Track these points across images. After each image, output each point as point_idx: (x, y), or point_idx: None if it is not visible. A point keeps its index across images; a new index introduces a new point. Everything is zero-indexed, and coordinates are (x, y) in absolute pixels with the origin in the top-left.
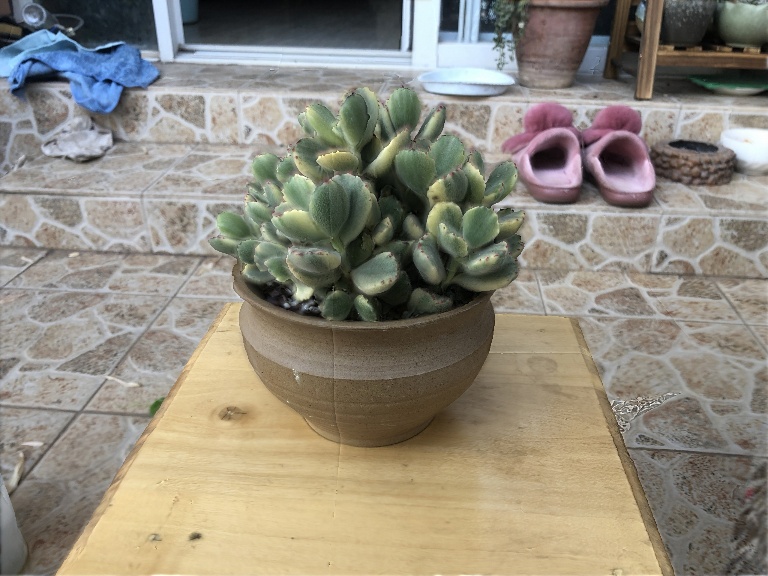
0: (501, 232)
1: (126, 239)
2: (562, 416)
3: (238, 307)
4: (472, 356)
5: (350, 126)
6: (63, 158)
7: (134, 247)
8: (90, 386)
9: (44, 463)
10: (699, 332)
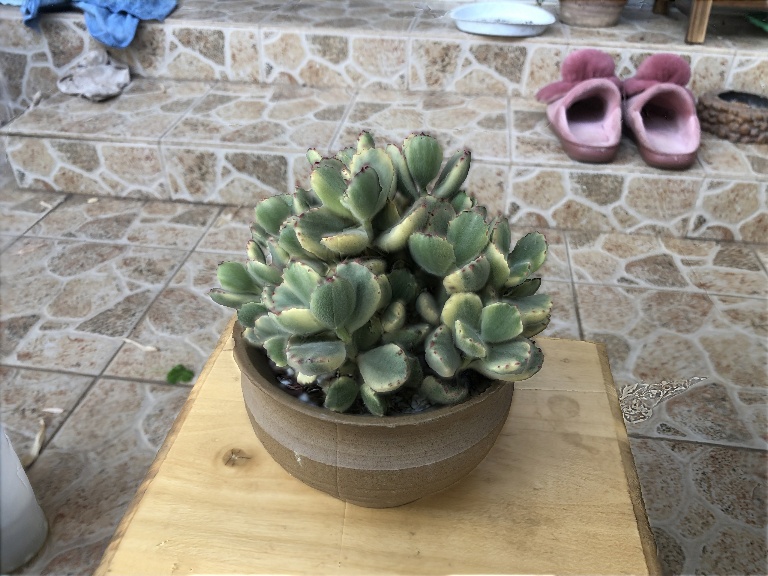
0: (525, 321)
1: (144, 186)
2: (581, 475)
3: None
4: (487, 438)
5: (359, 205)
6: (79, 96)
7: (153, 194)
8: (109, 349)
9: (64, 431)
10: (733, 308)
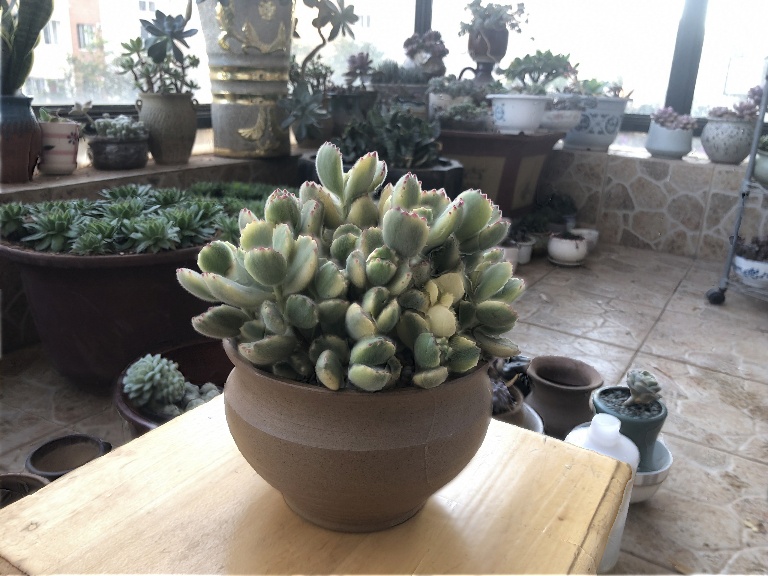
0: None
1: None
2: None
3: (603, 460)
4: None
5: None
6: None
7: None
8: None
9: None
10: None
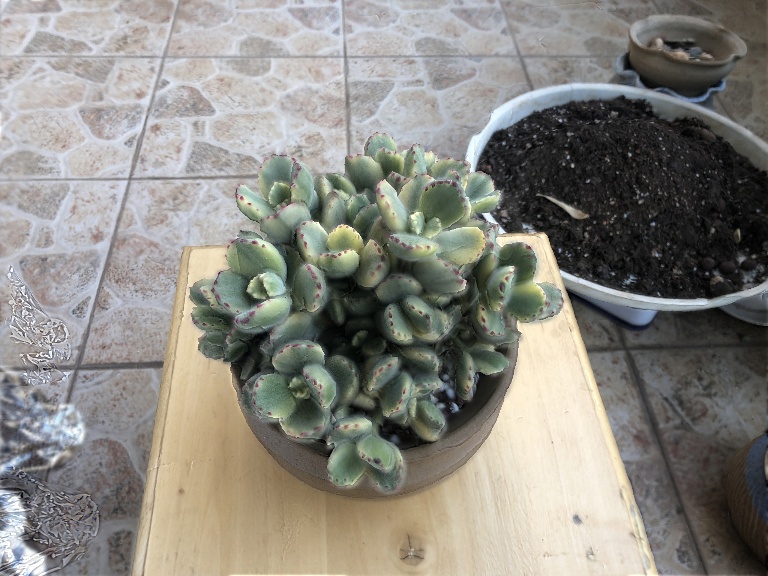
0: None
1: None
2: None
3: None
4: None
5: None
6: None
7: None
8: None
9: None
10: None
